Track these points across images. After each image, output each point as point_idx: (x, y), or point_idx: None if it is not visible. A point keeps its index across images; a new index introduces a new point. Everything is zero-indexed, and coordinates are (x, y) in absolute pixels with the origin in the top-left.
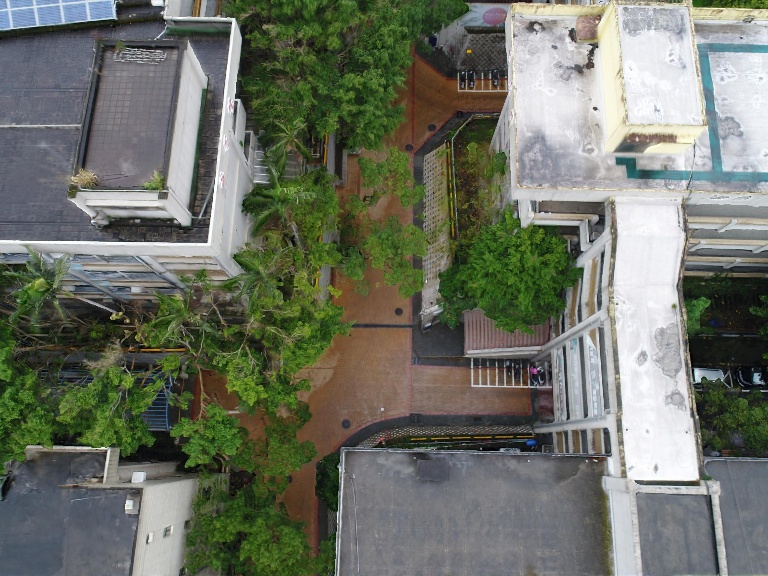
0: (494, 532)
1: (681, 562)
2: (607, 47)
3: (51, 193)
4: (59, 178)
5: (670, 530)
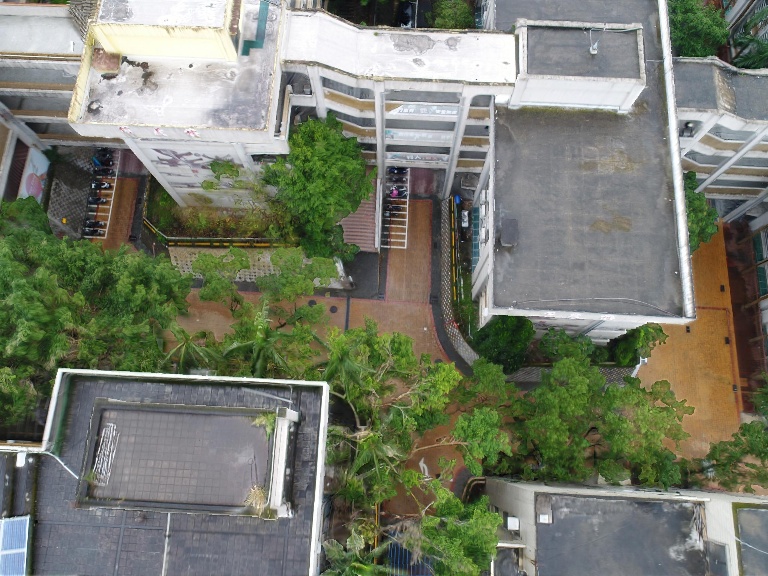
0: (555, 191)
1: (576, 51)
2: (134, 43)
3: (247, 575)
4: (229, 568)
5: (553, 56)
